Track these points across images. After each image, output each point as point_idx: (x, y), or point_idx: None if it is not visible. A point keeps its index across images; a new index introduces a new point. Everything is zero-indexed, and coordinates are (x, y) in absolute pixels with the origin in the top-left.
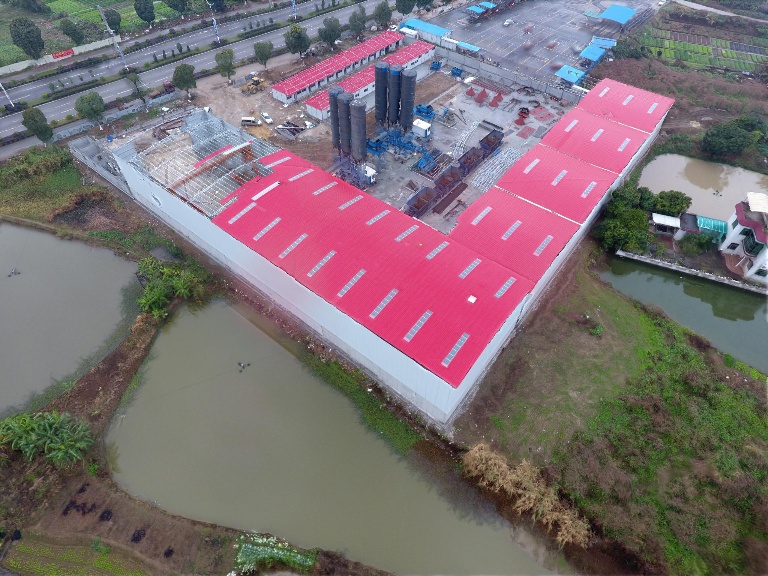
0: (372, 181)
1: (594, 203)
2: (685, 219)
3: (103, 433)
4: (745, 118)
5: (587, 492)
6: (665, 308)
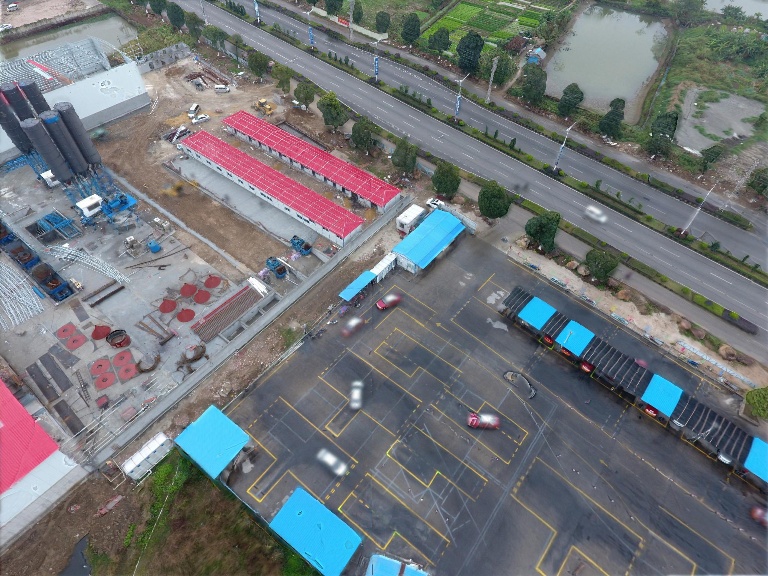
0: None
1: None
2: None
3: None
4: None
5: None
6: None
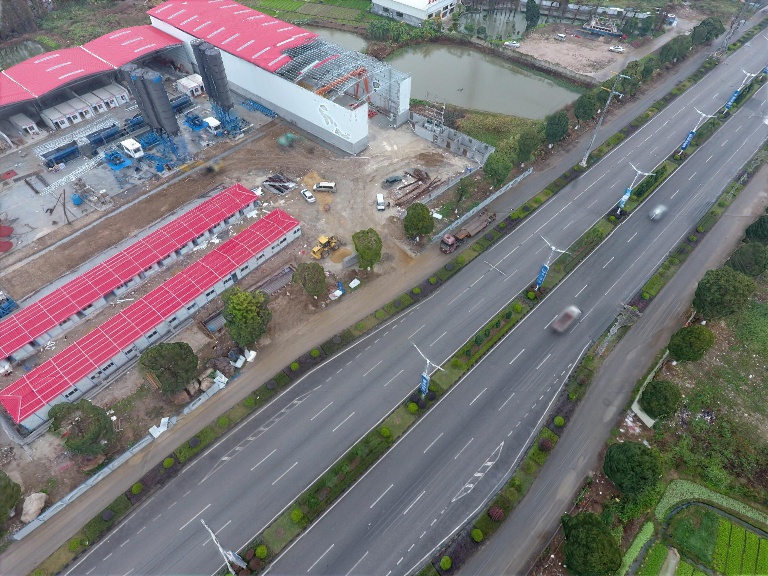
0: None
1: None
2: None
3: None
4: None
5: None
6: None
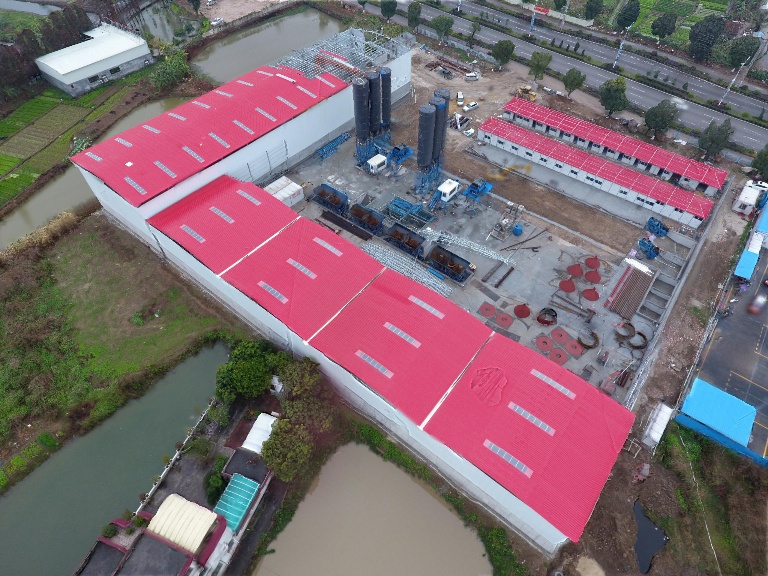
0: (372, 171)
1: (246, 290)
2: (255, 462)
3: (174, 95)
4: None
5: (7, 269)
6: (148, 409)
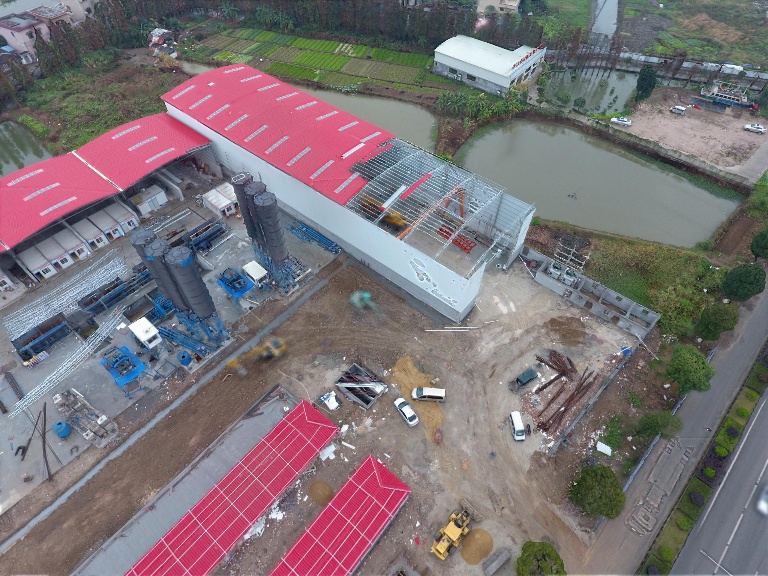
0: None
1: (39, 164)
2: None
3: None
4: None
5: None
6: None
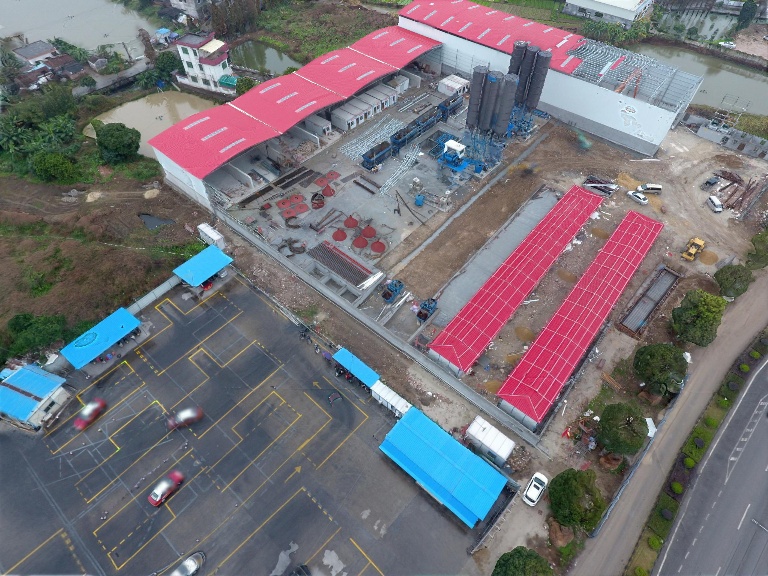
0: None
1: None
2: None
3: None
4: (58, 157)
5: None
6: None
